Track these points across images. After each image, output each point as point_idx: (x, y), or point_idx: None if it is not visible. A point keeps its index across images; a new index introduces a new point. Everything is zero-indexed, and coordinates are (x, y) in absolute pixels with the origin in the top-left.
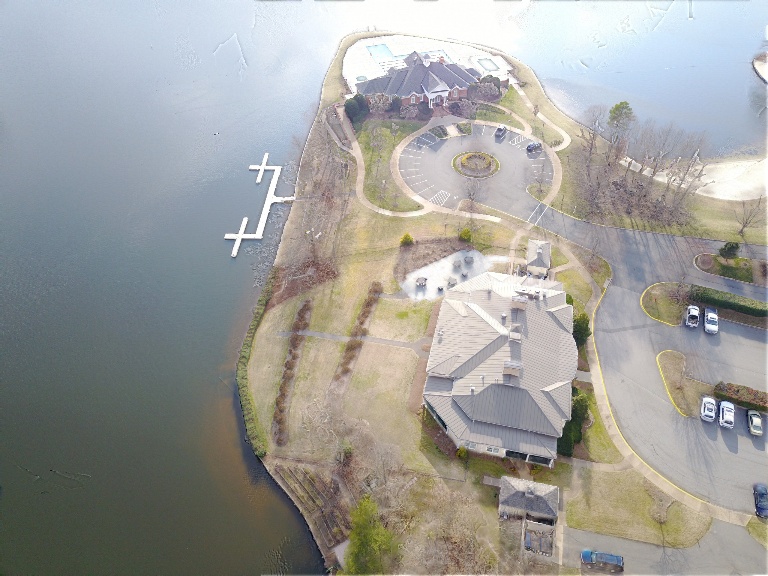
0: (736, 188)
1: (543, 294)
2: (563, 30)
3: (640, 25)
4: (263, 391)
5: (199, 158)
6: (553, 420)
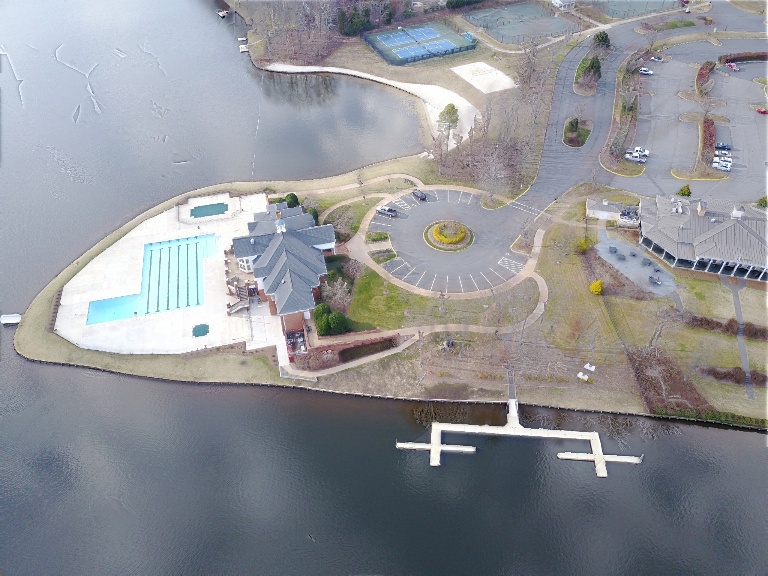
0: (466, 117)
1: None
2: (125, 152)
3: (166, 101)
4: None
5: (377, 567)
6: None
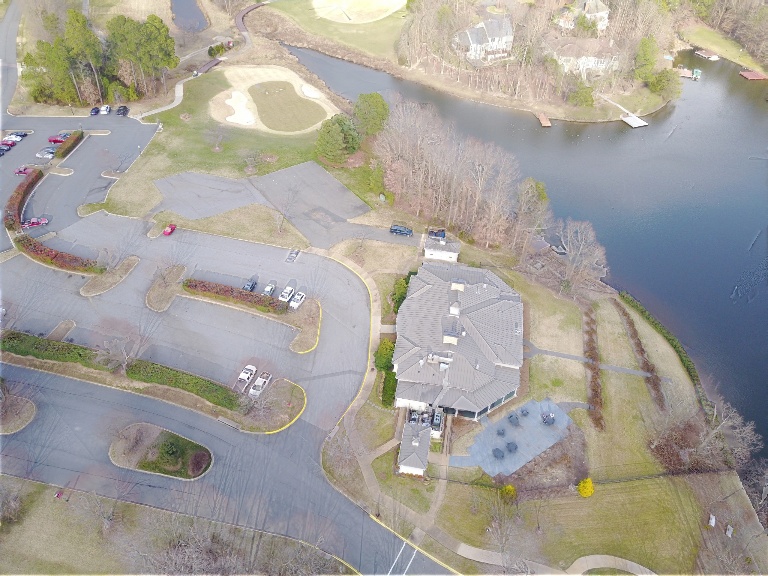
0: None
1: None
2: None
3: None
4: (649, 333)
5: None
6: (425, 273)
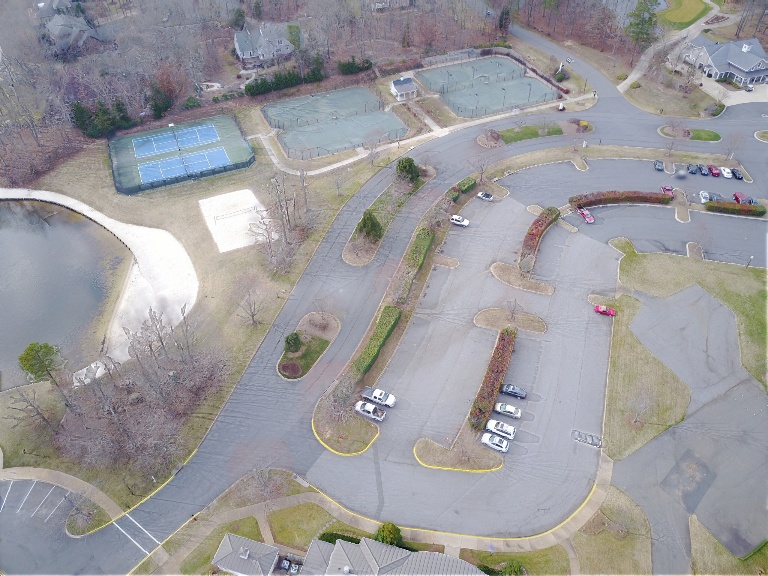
0: (173, 298)
1: (348, 572)
2: None
3: None
4: None
5: None
6: None
